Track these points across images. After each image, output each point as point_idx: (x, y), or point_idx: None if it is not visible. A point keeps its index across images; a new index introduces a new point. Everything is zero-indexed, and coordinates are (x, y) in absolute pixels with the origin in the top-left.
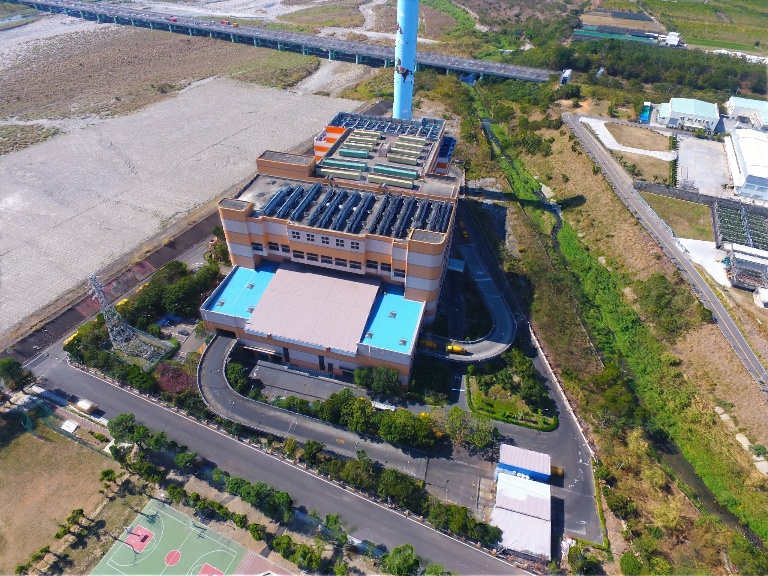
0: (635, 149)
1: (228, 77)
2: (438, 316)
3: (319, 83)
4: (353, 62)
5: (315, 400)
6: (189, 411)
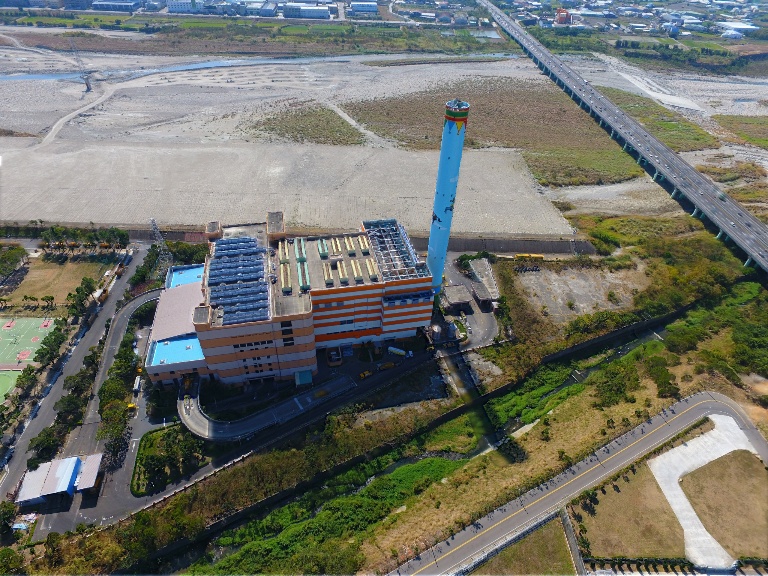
0: (683, 501)
1: (524, 154)
2: (230, 384)
3: (587, 196)
4: (671, 194)
5: (142, 351)
6: (116, 303)
